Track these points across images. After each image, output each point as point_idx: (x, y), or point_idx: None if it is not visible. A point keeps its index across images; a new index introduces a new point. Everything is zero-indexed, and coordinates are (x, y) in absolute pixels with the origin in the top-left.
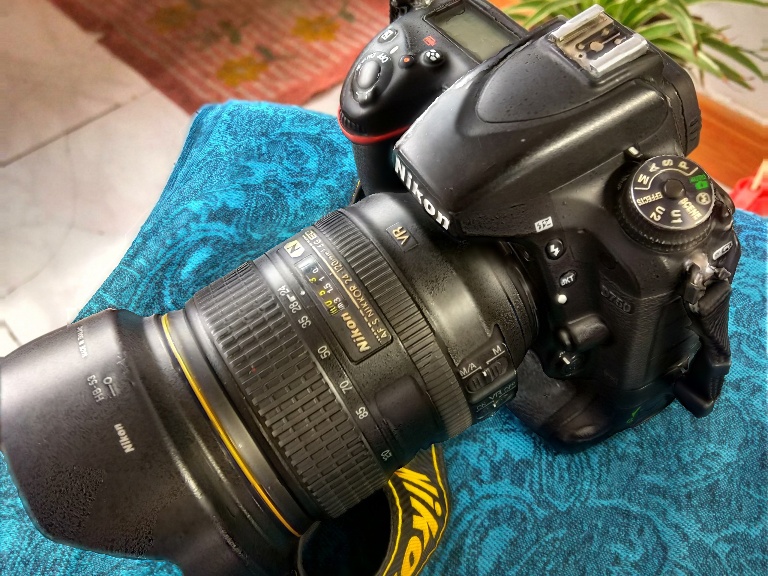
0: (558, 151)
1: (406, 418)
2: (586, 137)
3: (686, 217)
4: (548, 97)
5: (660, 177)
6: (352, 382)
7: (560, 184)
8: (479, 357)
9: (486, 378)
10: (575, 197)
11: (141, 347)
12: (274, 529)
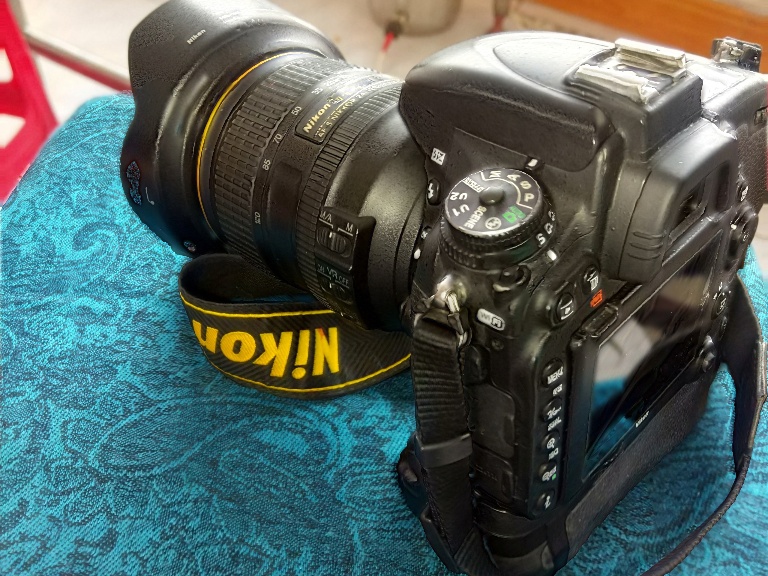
0: (486, 99)
1: (279, 203)
2: (510, 107)
3: (464, 217)
4: (536, 63)
5: (503, 184)
6: (282, 141)
7: (467, 130)
8: (338, 217)
9: (330, 240)
10: (469, 155)
11: (281, 39)
12: (190, 179)
